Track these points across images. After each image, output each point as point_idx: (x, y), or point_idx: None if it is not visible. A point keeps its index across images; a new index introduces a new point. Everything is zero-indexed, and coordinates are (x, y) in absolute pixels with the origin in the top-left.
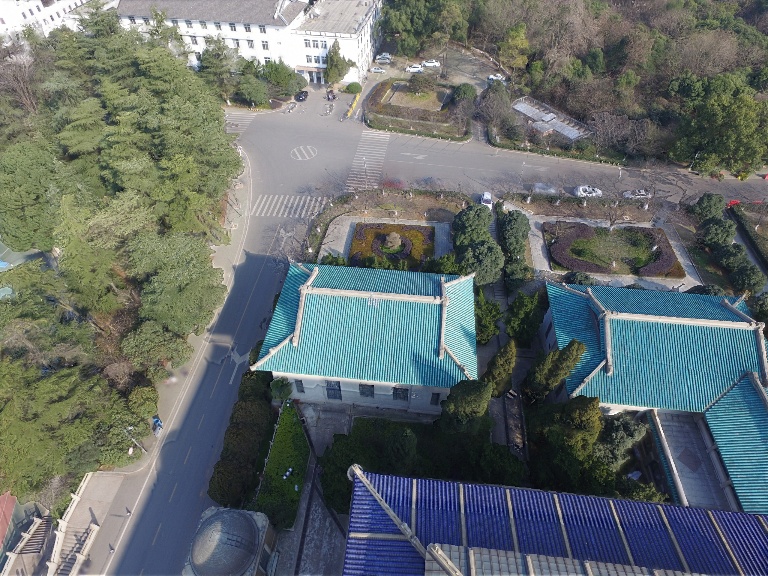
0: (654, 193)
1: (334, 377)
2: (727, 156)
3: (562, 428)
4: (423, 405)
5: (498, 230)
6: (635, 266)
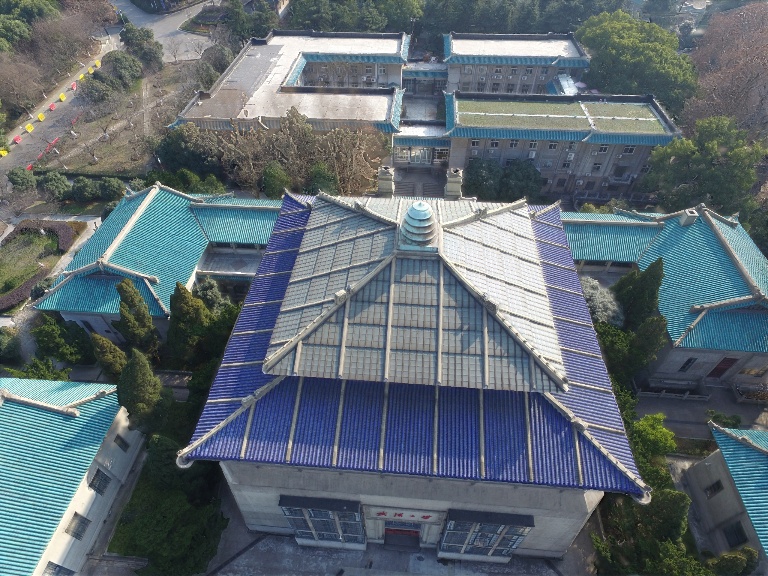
0: None
1: (39, 567)
2: None
3: (192, 327)
4: (123, 462)
5: None
6: (54, 250)
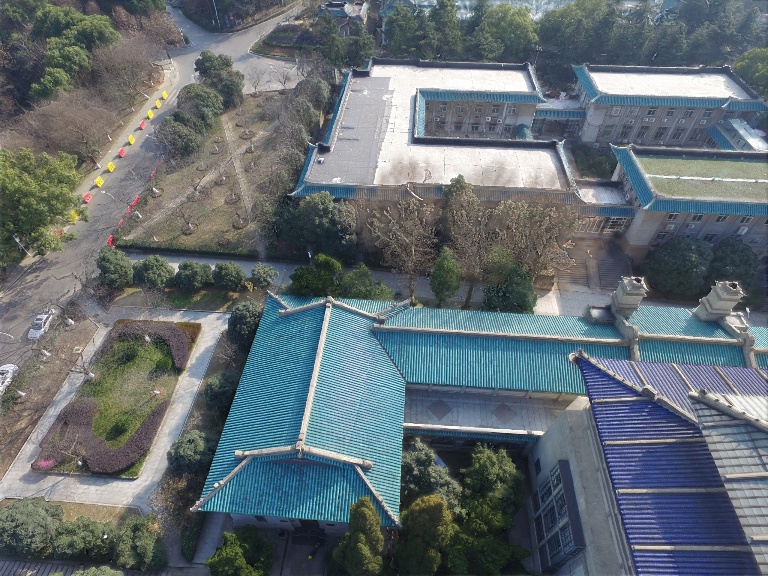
0: (58, 307)
1: None
2: (49, 218)
3: None
4: None
5: (7, 556)
6: (168, 369)
